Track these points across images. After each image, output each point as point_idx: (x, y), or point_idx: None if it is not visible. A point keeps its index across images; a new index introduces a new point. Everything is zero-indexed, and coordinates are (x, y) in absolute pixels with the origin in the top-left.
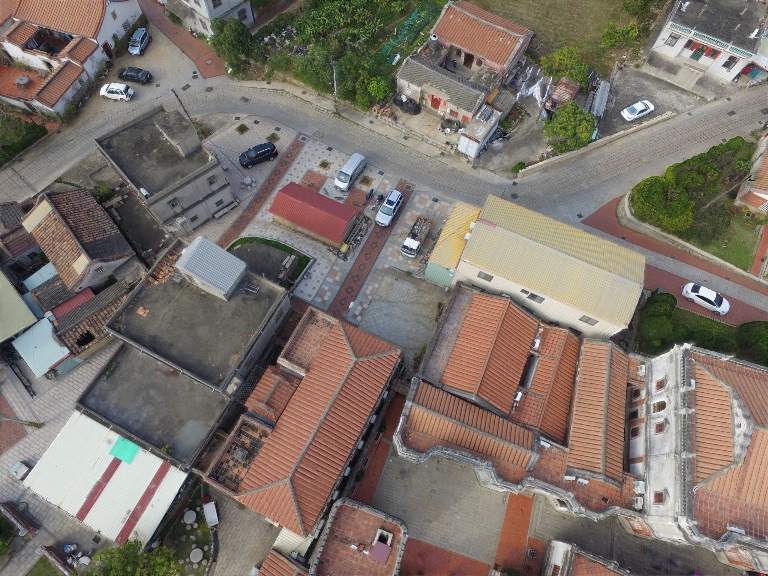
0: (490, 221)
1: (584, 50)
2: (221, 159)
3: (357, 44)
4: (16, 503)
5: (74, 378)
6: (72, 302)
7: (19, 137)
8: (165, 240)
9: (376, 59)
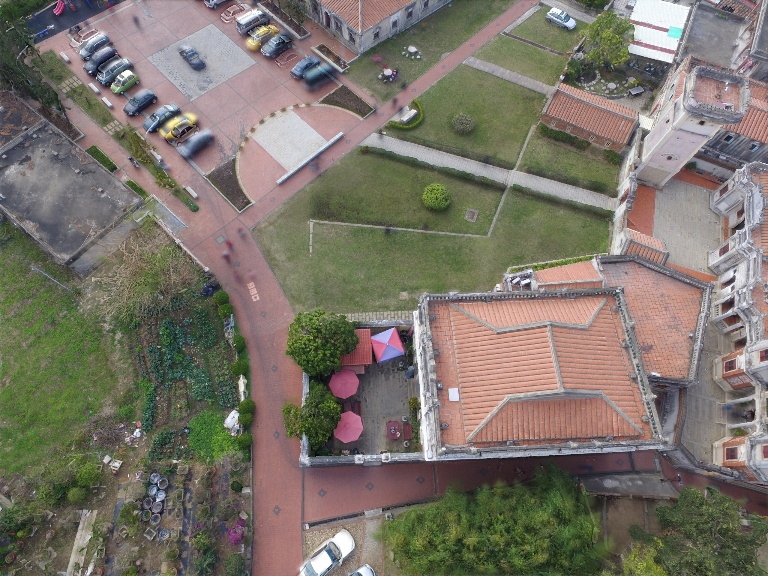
0: None
1: None
2: None
3: None
4: (613, 8)
5: None
6: (747, 2)
7: None
8: None
9: None
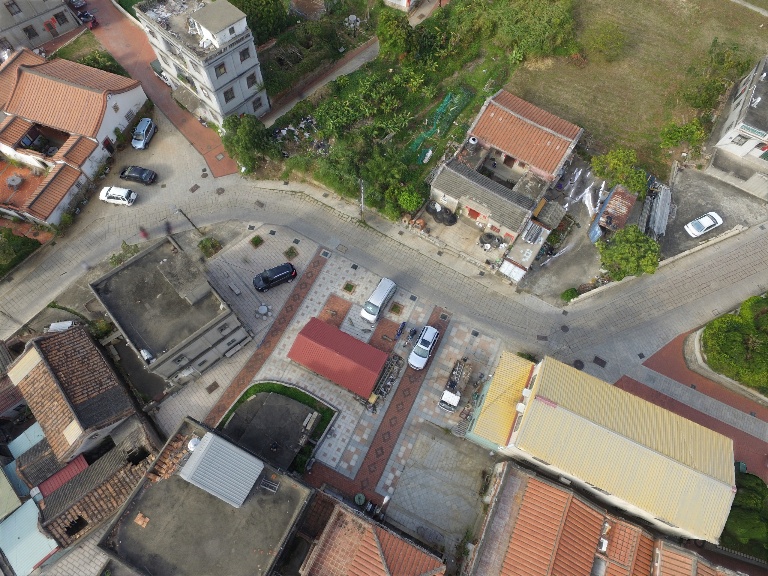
0: (549, 398)
1: (638, 145)
2: (233, 280)
3: (385, 141)
4: None
5: (63, 568)
6: (62, 474)
7: (7, 261)
8: (169, 390)
9: (405, 156)
